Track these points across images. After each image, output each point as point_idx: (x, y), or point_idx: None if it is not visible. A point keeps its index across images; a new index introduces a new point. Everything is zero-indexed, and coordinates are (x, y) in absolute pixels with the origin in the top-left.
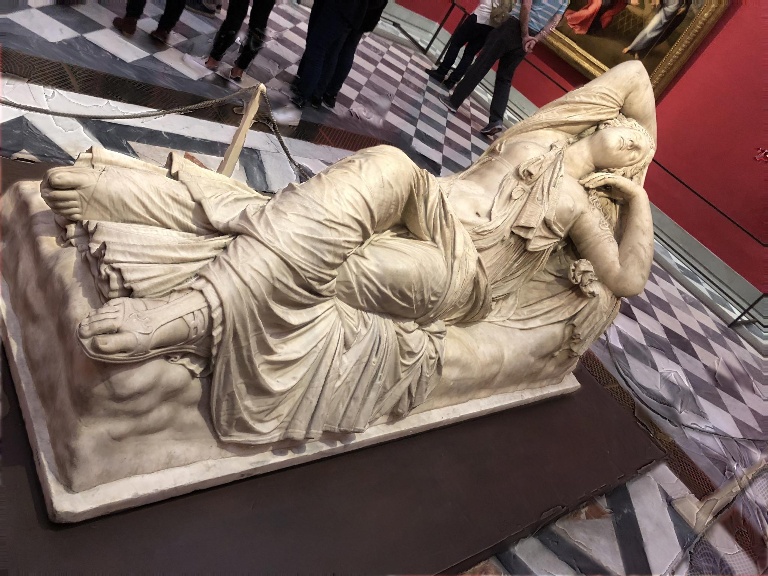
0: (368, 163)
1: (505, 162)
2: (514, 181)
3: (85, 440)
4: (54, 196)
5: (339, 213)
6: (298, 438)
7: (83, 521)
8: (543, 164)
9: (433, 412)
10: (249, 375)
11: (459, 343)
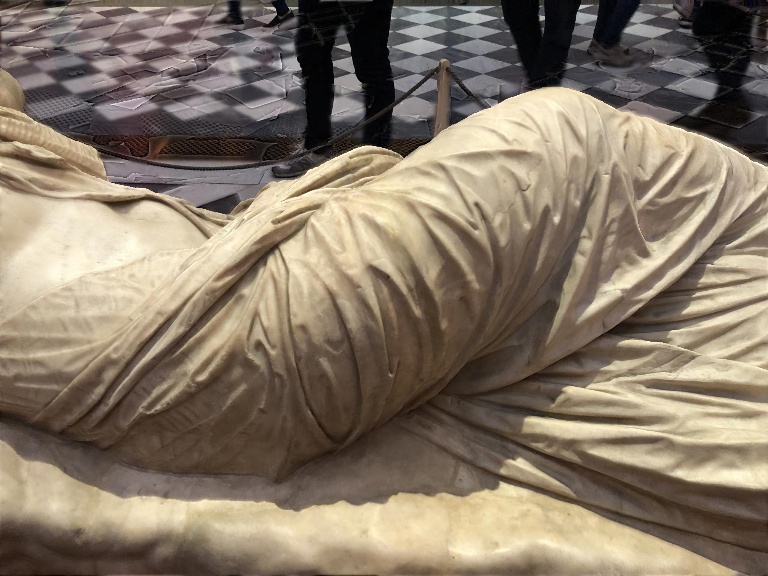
0: None
1: None
2: None
3: None
4: None
5: None
6: None
7: None
8: None
9: None
10: None
11: None
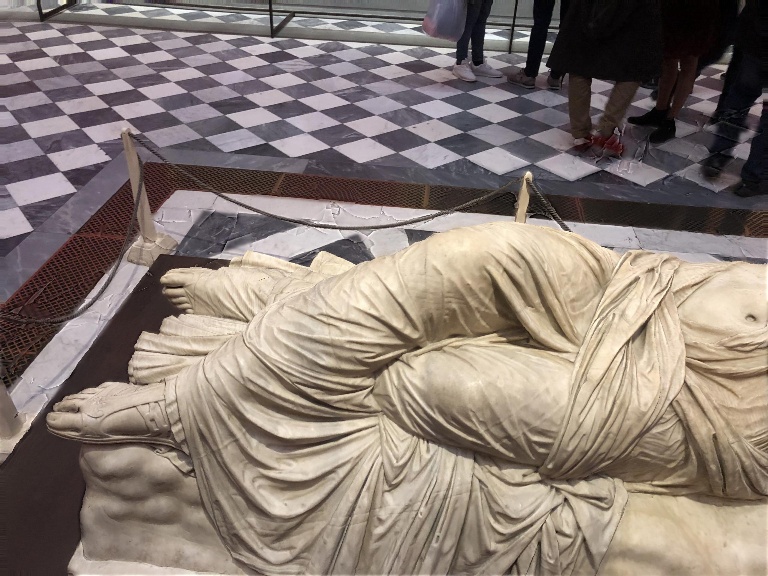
0: (418, 244)
1: None
2: None
3: (86, 510)
4: (167, 293)
5: (344, 307)
6: None
7: None
8: None
9: None
10: (237, 487)
11: (668, 527)
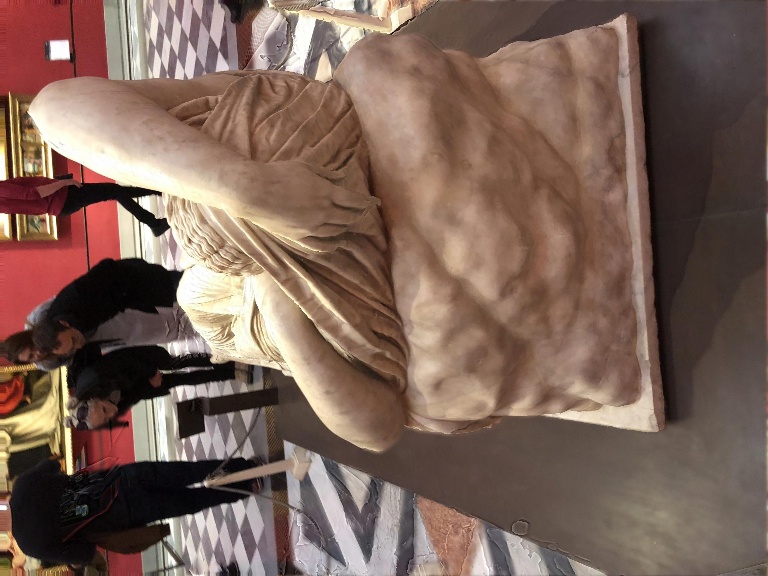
0: None
1: None
2: None
3: None
4: None
5: None
6: None
7: None
8: None
9: None
10: None
11: None
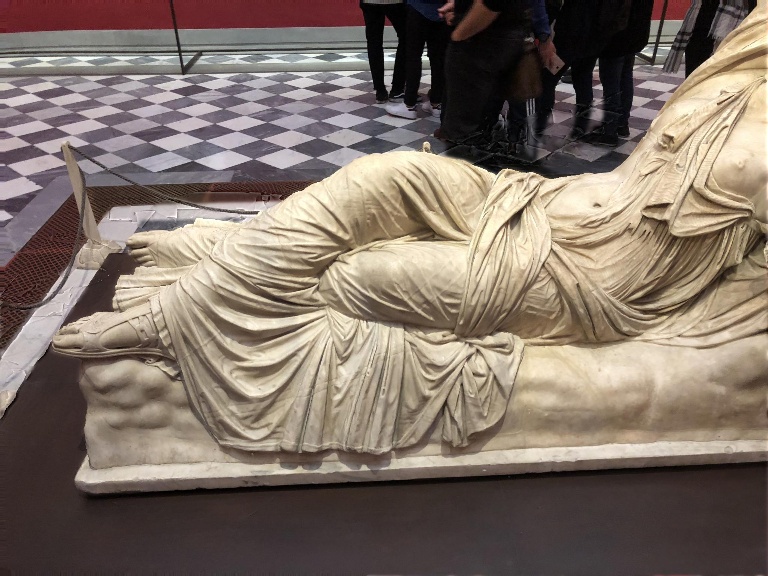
0: (340, 170)
1: (650, 135)
2: (653, 153)
3: (89, 424)
4: (133, 254)
5: (288, 220)
6: (287, 448)
7: (103, 494)
8: (691, 120)
9: (528, 451)
10: (218, 379)
11: (557, 363)
